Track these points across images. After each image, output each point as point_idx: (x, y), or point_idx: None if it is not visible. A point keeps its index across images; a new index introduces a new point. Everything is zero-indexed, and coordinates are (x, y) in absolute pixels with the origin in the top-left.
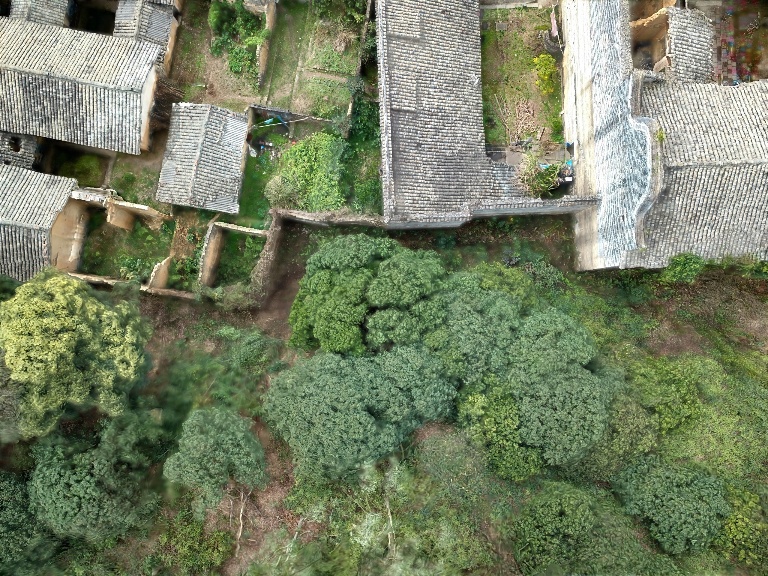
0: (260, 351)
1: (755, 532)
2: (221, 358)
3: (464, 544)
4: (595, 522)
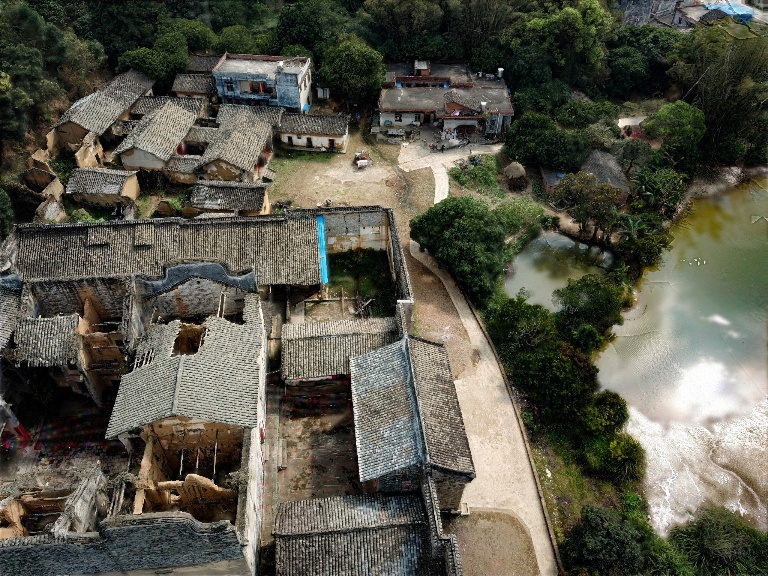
0: None
1: None
2: None
3: None
4: None
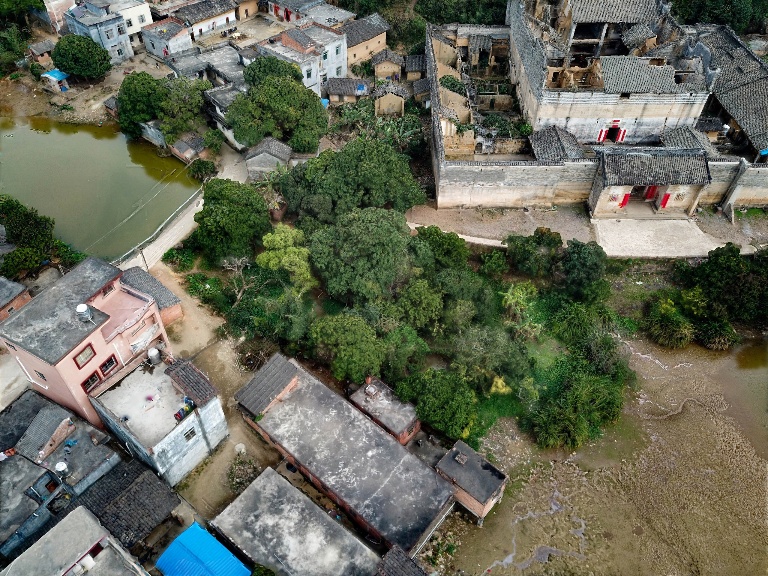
0: (754, 8)
1: None
2: (767, 10)
3: None
4: None
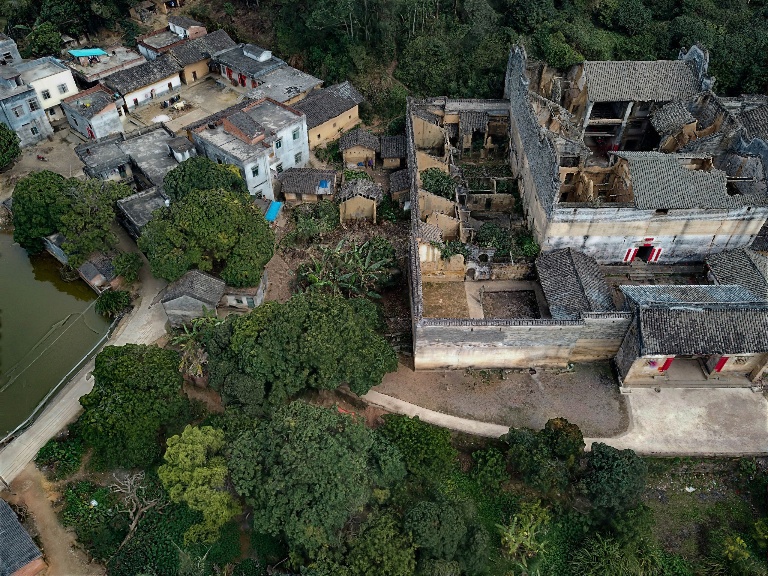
0: None
1: (609, 3)
2: None
3: (710, 7)
4: (671, 1)
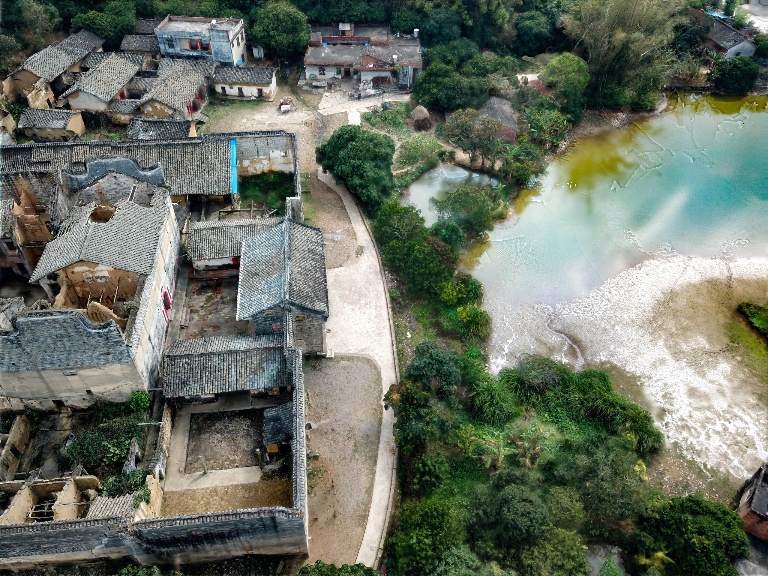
0: None
1: None
2: None
3: None
4: None
